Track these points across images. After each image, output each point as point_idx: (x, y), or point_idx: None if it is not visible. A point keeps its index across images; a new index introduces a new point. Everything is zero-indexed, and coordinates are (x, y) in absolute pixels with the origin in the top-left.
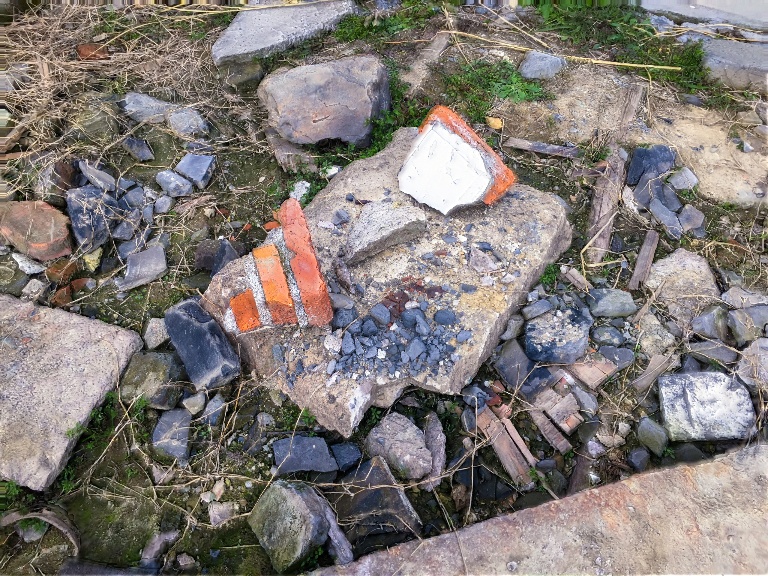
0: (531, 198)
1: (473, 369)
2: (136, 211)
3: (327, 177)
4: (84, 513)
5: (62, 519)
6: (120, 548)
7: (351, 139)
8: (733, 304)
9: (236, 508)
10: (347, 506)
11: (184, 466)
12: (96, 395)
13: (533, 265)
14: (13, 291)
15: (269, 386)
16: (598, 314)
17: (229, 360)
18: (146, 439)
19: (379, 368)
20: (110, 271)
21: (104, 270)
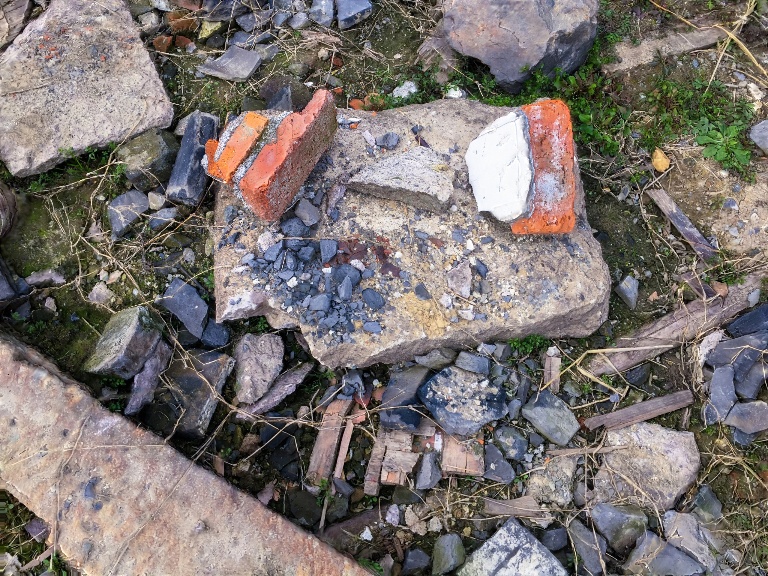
0: (583, 262)
1: (360, 360)
2: (269, 10)
3: (446, 96)
4: (31, 215)
5: (5, 207)
6: (25, 259)
7: (499, 76)
8: (666, 528)
9: (111, 300)
10: (178, 370)
11: (112, 240)
12: (99, 138)
13: (508, 323)
14: (134, 12)
15: (212, 233)
16: (526, 416)
17: (190, 188)
18: (110, 198)
19: (280, 292)
20: (212, 48)
21: (208, 43)
